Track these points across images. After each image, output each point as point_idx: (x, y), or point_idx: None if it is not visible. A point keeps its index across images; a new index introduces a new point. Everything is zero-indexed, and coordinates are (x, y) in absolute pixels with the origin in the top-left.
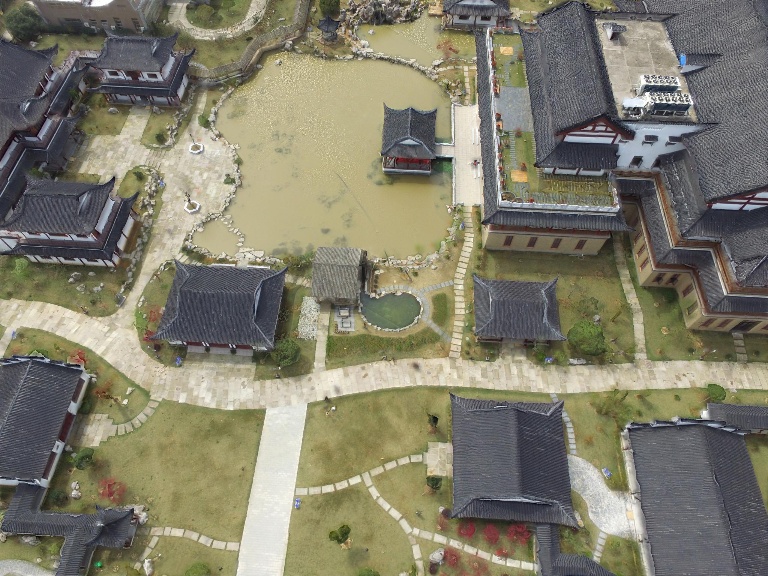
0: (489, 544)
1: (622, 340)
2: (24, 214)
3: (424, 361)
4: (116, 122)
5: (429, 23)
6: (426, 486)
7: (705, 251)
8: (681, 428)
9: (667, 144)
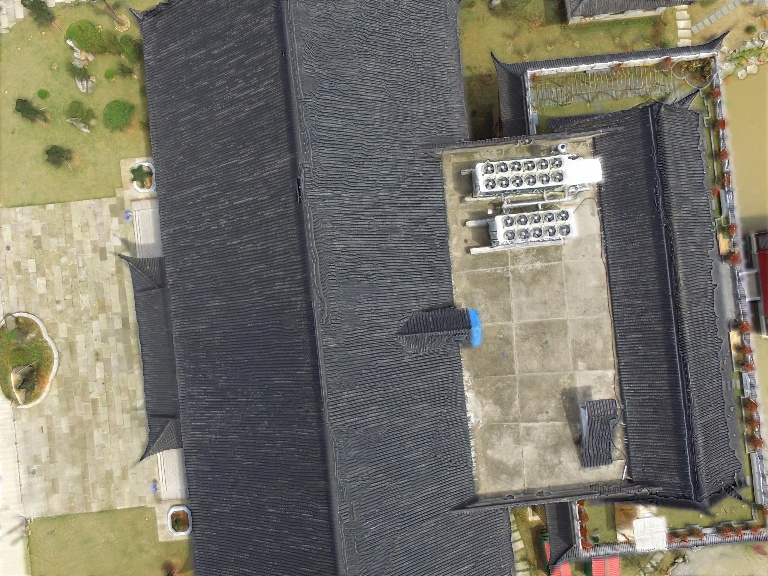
0: None
1: None
2: None
3: None
4: None
5: None
6: None
7: None
8: None
9: None
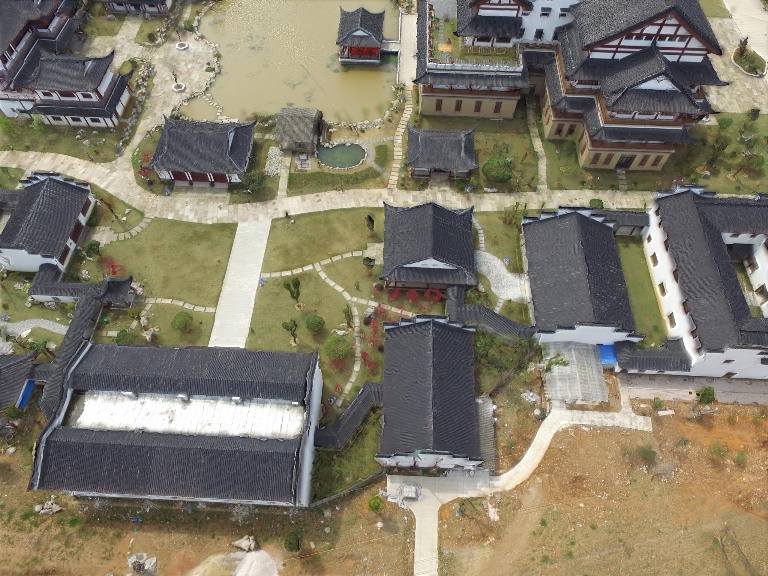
0: (411, 306)
1: (528, 176)
2: (40, 76)
3: (367, 191)
4: (114, 26)
5: None
6: (364, 270)
7: (590, 98)
8: (560, 217)
9: (560, 16)
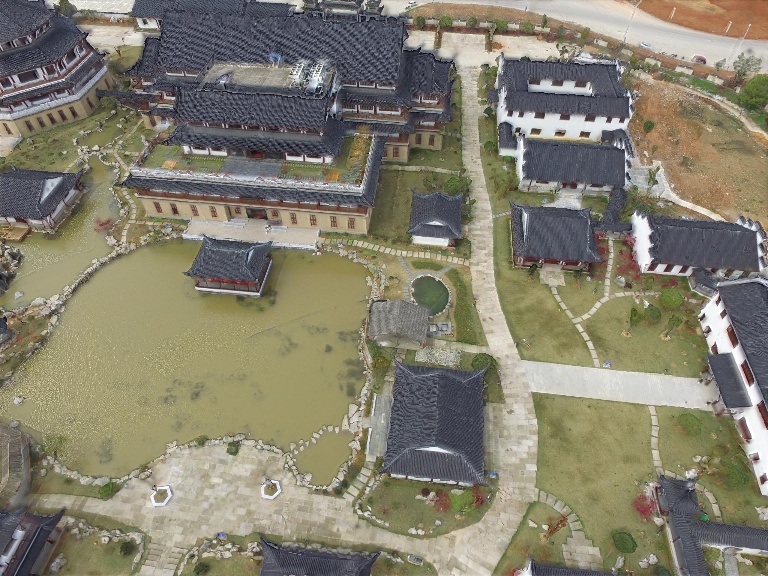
0: None
1: None
2: None
3: (474, 281)
4: None
5: (34, 243)
6: (574, 286)
7: None
8: (525, 154)
9: None
